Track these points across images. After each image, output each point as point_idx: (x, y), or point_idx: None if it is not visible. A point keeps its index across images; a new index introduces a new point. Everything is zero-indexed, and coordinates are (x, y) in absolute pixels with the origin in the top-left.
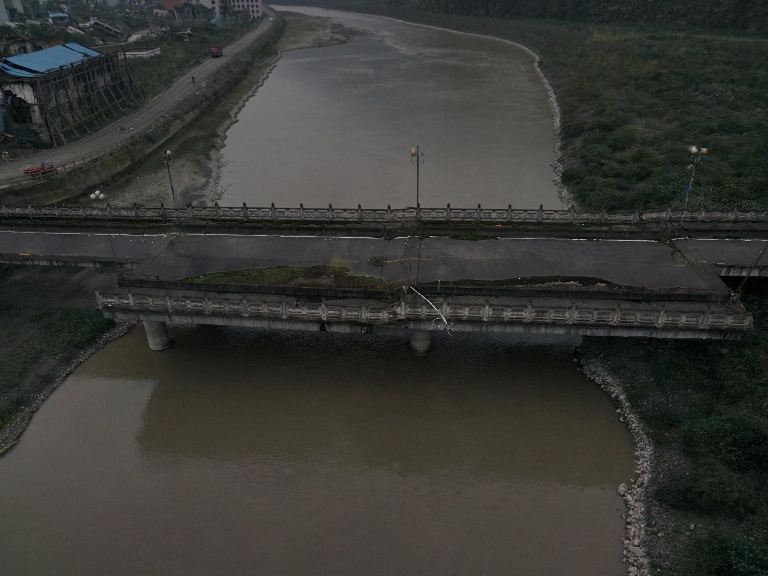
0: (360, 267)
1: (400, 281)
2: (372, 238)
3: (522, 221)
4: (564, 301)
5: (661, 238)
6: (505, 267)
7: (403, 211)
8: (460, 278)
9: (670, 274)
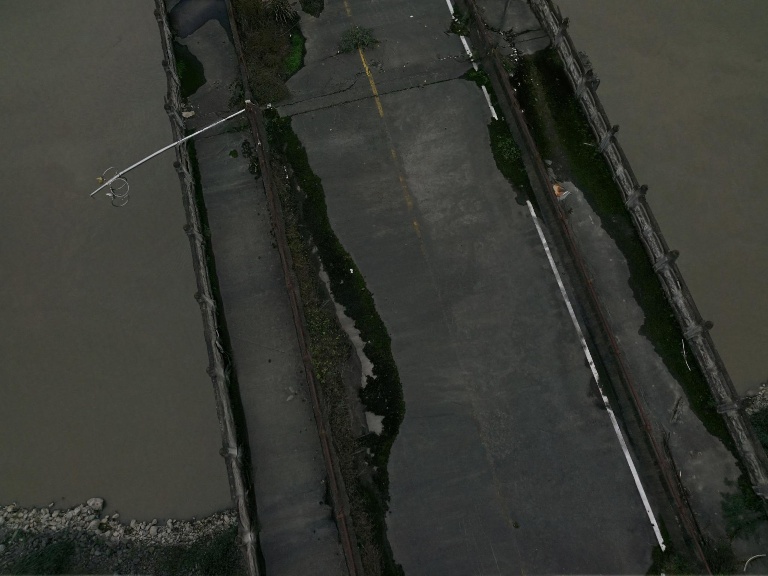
0: (331, 24)
1: (296, 92)
2: (448, 3)
3: (640, 233)
4: (291, 359)
5: (675, 559)
6: (391, 238)
7: (550, 8)
8: (323, 175)
9: (473, 572)
